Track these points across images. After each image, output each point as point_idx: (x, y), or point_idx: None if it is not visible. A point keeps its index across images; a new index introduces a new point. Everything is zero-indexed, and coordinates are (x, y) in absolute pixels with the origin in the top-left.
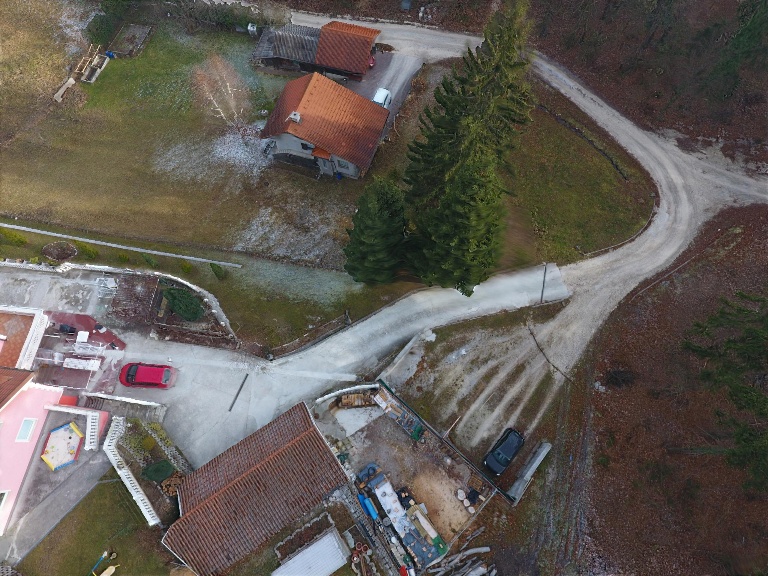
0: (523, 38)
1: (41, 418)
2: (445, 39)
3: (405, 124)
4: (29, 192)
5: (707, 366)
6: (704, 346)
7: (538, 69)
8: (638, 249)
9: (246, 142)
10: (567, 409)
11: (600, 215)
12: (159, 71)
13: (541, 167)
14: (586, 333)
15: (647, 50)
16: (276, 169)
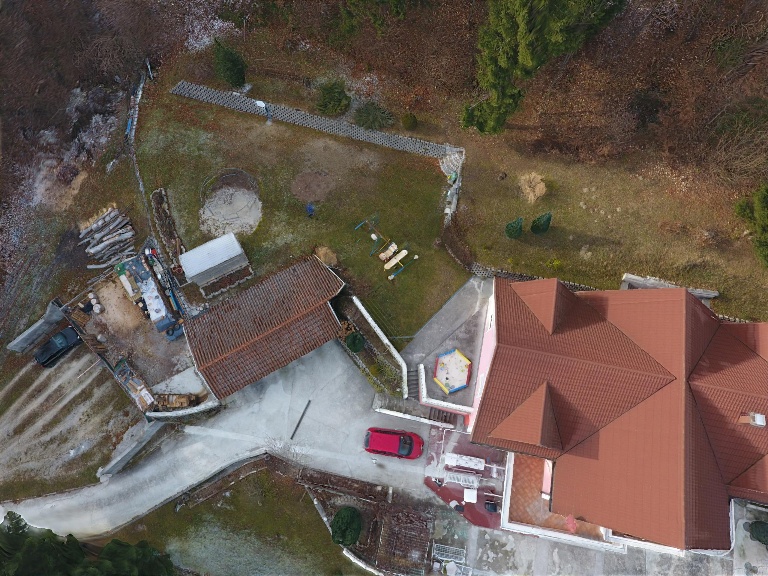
0: None
1: None
2: None
3: None
4: None
5: None
6: None
7: None
8: None
9: None
10: None
11: None
12: None
13: None
14: None
15: None
16: None
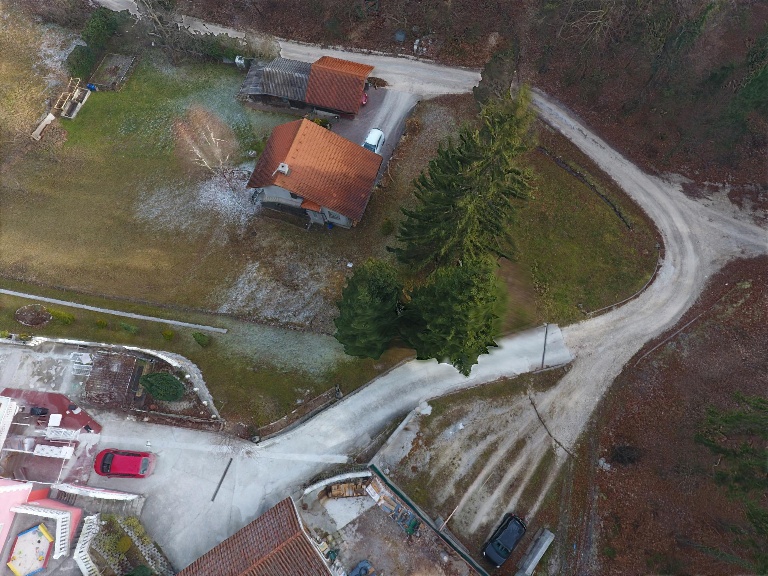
0: (522, 74)
1: (7, 521)
2: (441, 74)
3: (399, 168)
4: (3, 244)
5: (721, 464)
6: None
7: (537, 107)
8: (643, 306)
9: (233, 186)
10: (570, 490)
11: (603, 269)
12: (143, 105)
13: (541, 217)
14: (589, 402)
15: (652, 95)
16: (264, 218)
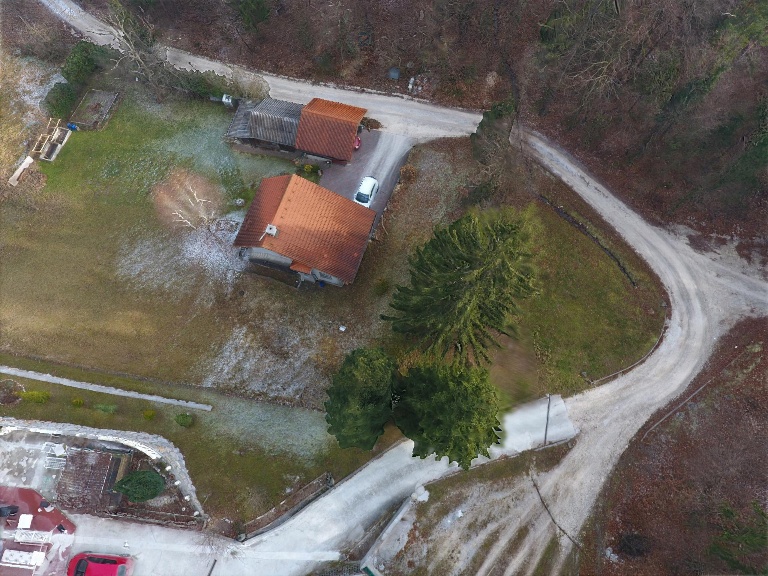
0: (521, 116)
1: None
2: (437, 115)
3: (394, 220)
4: None
5: None
6: (725, 503)
7: (538, 153)
8: (649, 372)
9: None
10: None
11: (607, 332)
12: (126, 146)
13: (543, 275)
14: (595, 483)
15: (658, 147)
16: (252, 275)
